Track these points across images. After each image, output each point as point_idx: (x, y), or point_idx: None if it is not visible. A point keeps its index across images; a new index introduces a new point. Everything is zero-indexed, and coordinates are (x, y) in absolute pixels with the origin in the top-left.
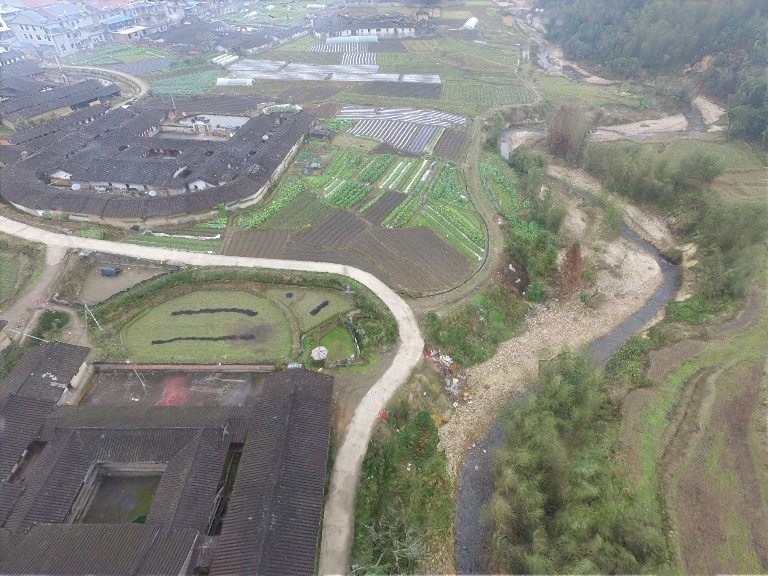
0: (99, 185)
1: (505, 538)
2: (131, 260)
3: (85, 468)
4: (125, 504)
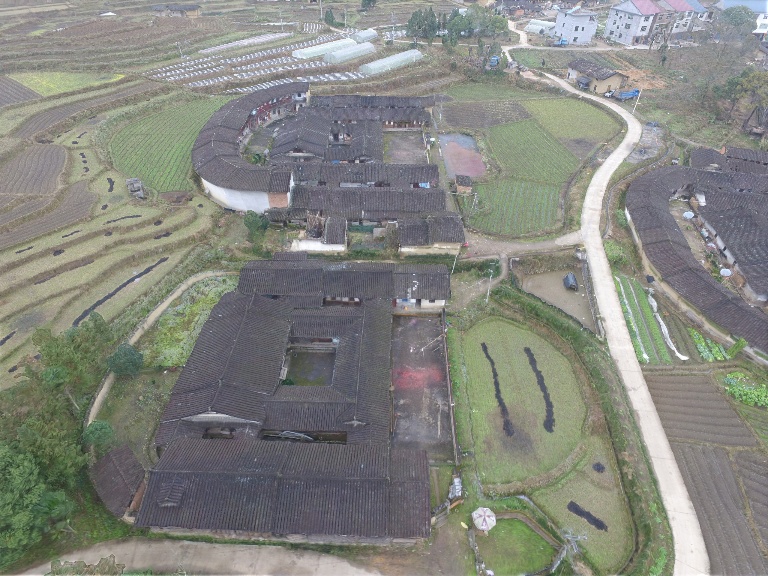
0: (709, 229)
1: None
2: (591, 291)
3: (333, 335)
4: (314, 373)
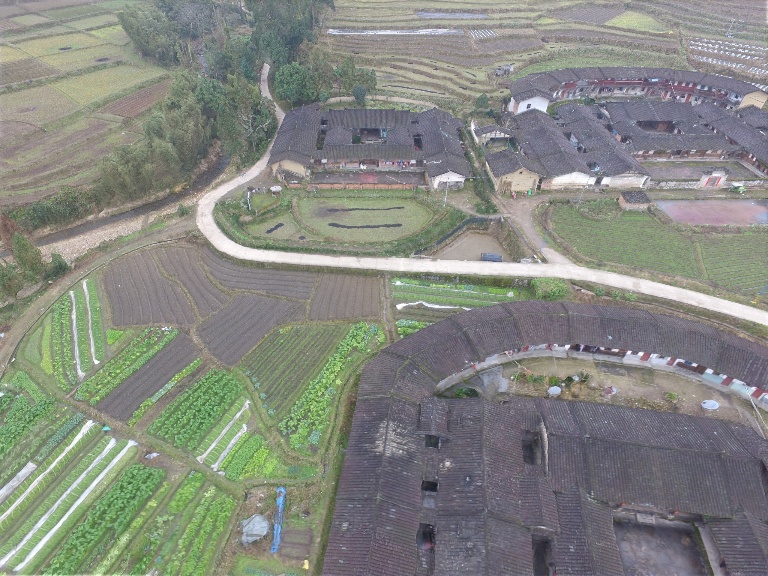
0: None
1: (205, 132)
2: None
3: None
4: None
